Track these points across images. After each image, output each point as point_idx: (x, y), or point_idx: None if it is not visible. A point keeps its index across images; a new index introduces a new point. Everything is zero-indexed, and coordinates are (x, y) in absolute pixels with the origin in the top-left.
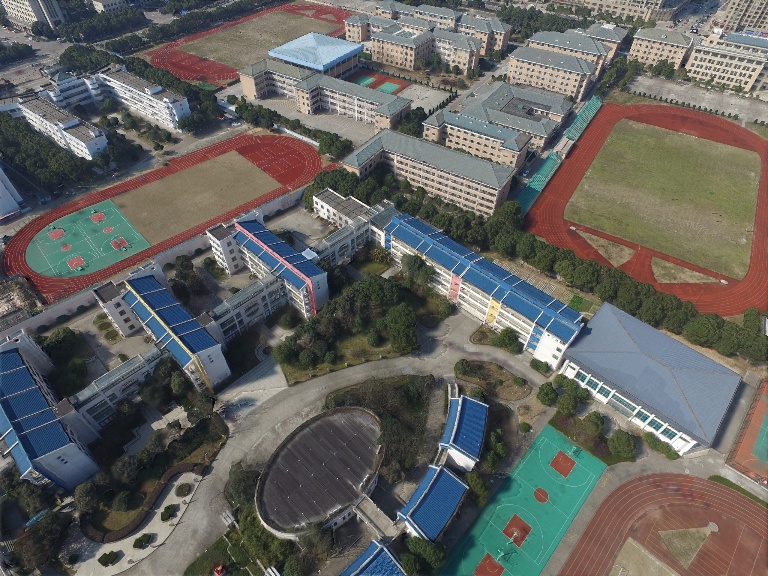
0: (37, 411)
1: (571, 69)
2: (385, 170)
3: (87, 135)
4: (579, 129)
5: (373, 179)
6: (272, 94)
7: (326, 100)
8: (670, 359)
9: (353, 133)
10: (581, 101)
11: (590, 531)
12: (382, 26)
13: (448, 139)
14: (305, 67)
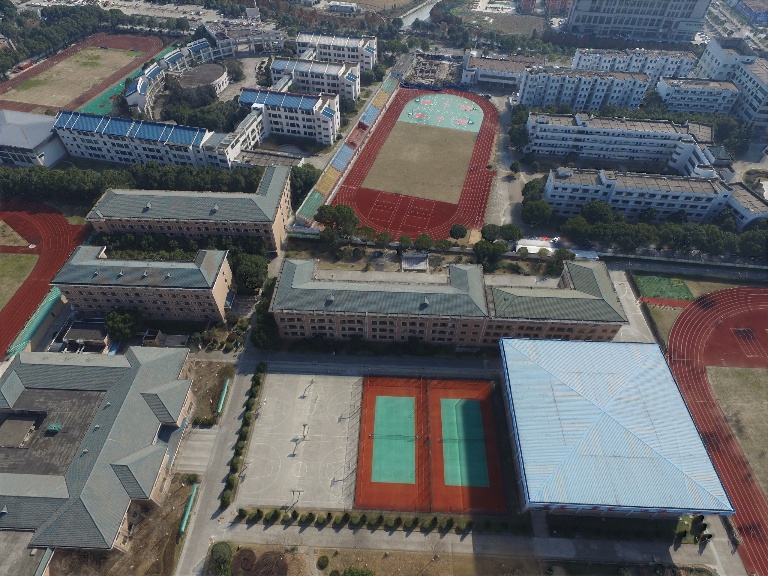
0: (320, 40)
1: None
2: None
3: None
4: None
5: None
6: None
7: None
8: (1, 128)
9: None
10: None
11: (80, 104)
12: None
13: None
14: None
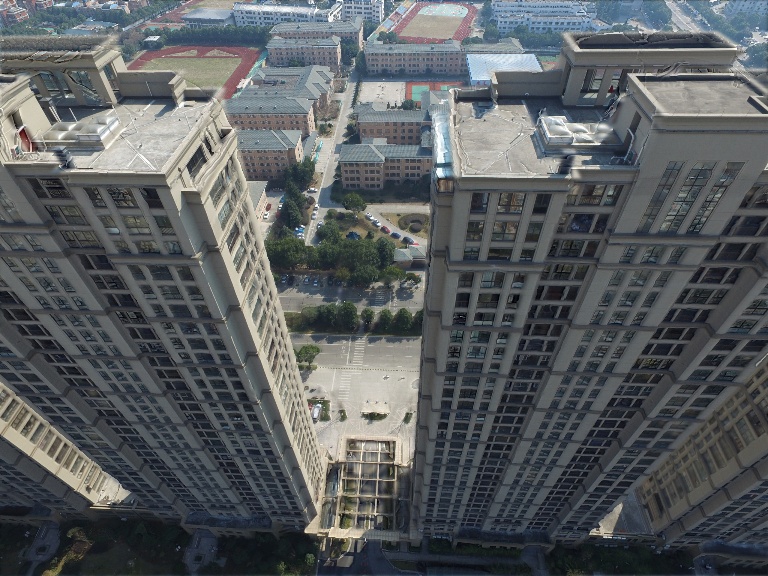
0: None
1: None
2: None
3: (502, 1)
4: None
5: None
6: None
7: None
8: None
9: None
10: None
11: None
12: None
13: None
14: None
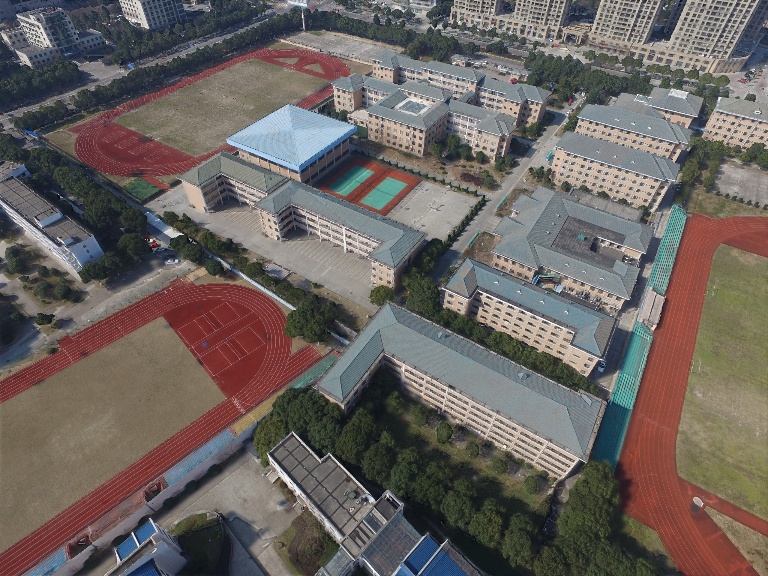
0: None
1: (647, 173)
2: (387, 384)
3: None
4: (665, 269)
5: (367, 412)
6: (230, 201)
7: (302, 221)
8: None
9: (340, 278)
10: (656, 211)
11: None
12: (381, 92)
13: (482, 308)
14: (276, 163)
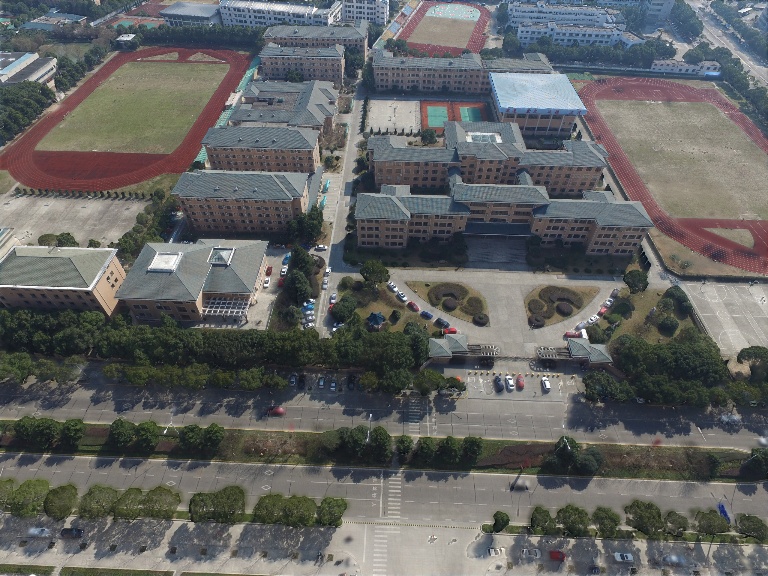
0: None
1: None
2: None
3: None
4: (221, 121)
5: None
6: None
7: None
8: None
9: None
10: None
11: None
12: None
13: None
14: None
